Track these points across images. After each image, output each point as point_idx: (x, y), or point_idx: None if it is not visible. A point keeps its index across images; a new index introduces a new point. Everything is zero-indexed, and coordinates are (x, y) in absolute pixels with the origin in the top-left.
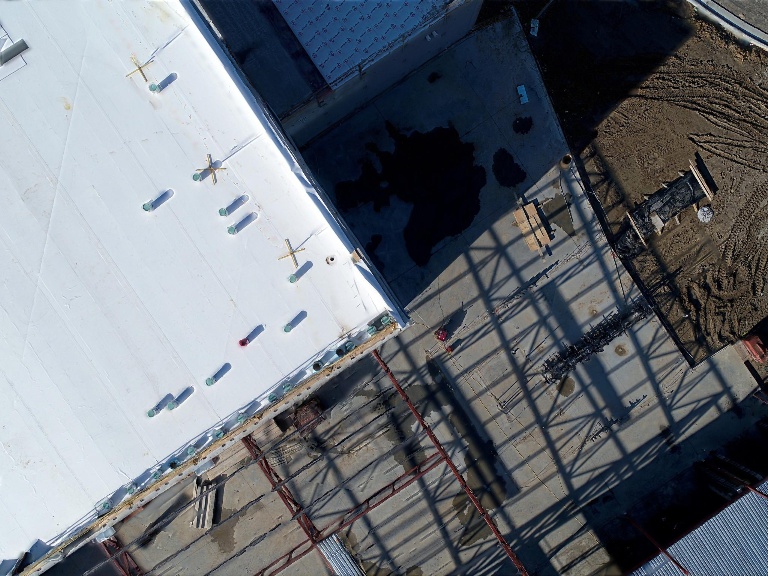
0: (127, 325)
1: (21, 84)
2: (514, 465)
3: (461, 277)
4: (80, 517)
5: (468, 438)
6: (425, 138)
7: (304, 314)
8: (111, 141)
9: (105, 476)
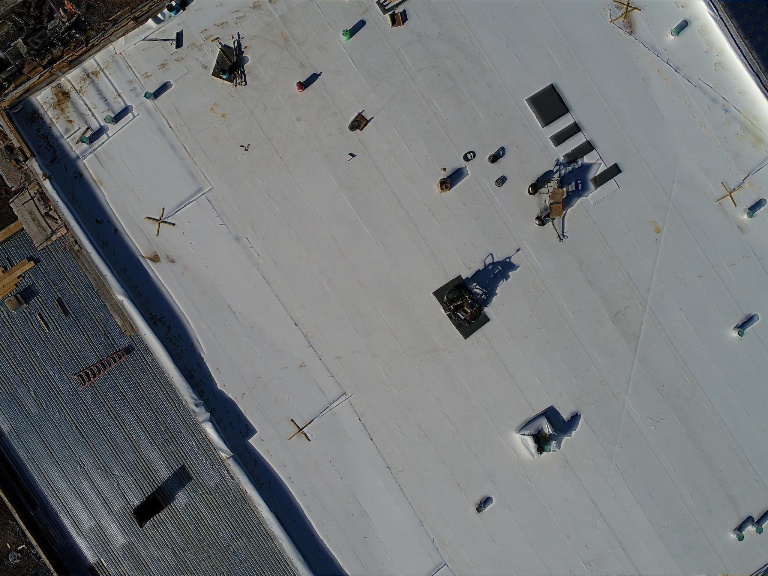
0: (711, 448)
1: (613, 208)
2: None
3: None
4: None
5: None
6: None
7: None
8: (699, 265)
9: None
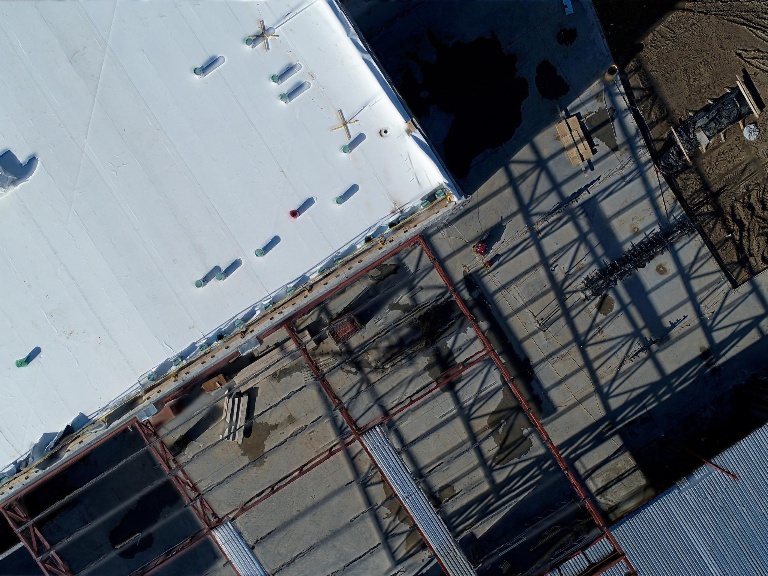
0: (175, 194)
1: None
2: (551, 384)
3: (501, 191)
4: (123, 391)
5: (504, 355)
6: (467, 48)
7: (356, 188)
8: (162, 5)
9: (149, 349)
